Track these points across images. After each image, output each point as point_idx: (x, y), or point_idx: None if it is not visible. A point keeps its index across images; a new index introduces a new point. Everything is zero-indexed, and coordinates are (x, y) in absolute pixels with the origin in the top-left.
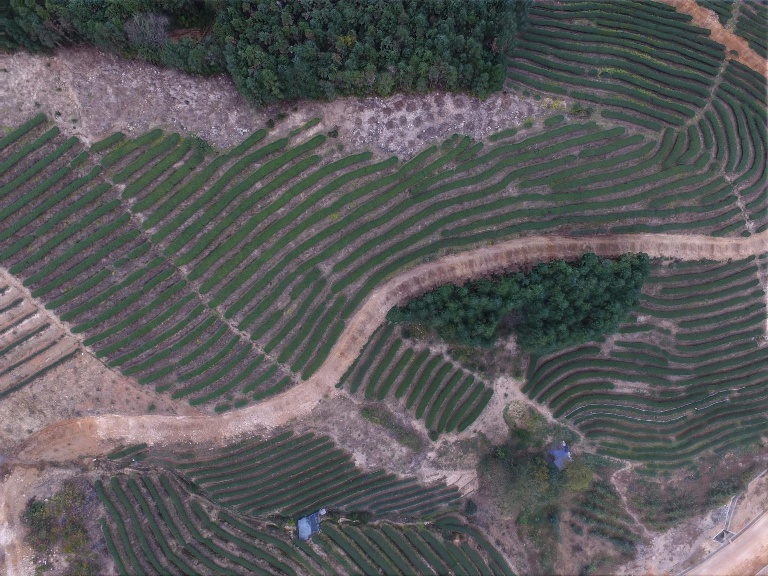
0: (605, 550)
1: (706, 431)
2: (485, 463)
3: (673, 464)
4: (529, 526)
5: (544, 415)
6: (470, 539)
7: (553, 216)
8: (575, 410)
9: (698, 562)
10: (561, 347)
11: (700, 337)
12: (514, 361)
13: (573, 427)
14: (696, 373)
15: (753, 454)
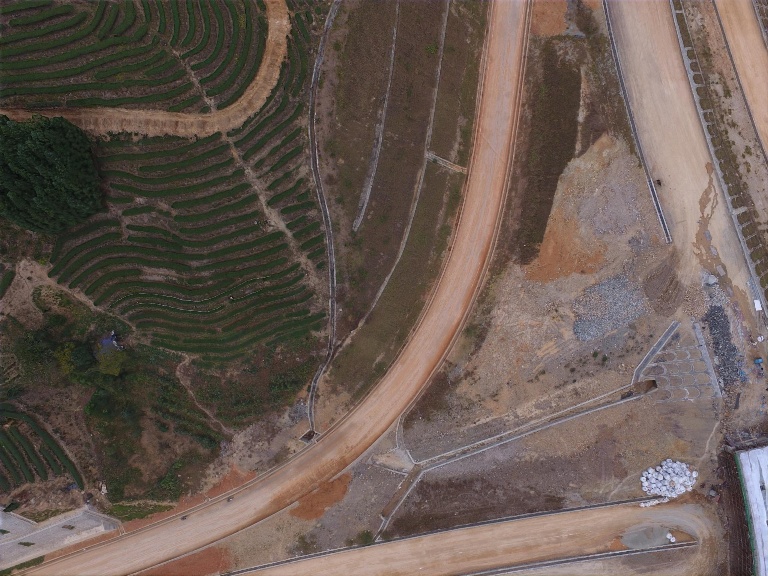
0: (194, 448)
1: (255, 324)
2: (20, 347)
3: (227, 357)
4: (99, 418)
5: (85, 303)
6: (24, 425)
7: (2, 87)
8: (119, 299)
9: (284, 461)
10: (49, 224)
11: (195, 218)
12: (35, 245)
13: (123, 317)
14: (208, 258)
15: (308, 349)
